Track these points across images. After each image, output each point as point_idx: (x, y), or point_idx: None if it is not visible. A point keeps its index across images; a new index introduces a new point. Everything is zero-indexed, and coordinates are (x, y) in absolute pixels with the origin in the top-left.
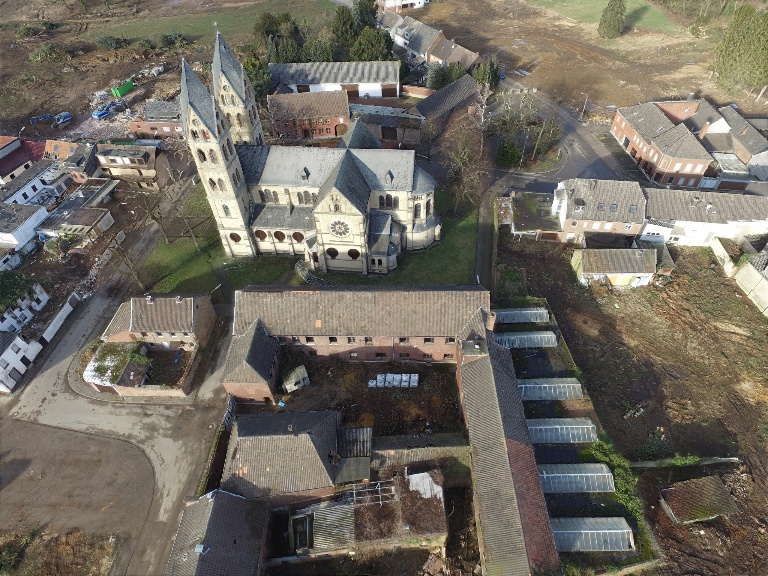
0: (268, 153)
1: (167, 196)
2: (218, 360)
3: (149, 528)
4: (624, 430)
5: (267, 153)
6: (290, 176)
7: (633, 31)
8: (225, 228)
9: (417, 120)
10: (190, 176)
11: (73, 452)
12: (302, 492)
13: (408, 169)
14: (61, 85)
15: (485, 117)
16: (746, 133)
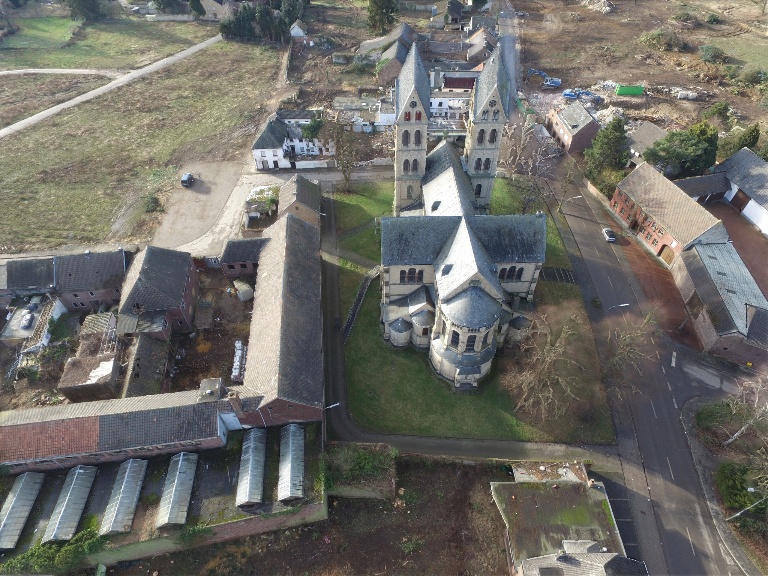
0: (446, 170)
1: None
2: None
3: None
4: None
5: (446, 169)
6: (432, 199)
7: None
8: None
9: (731, 323)
10: None
11: (211, 207)
12: None
13: (458, 280)
14: (611, 63)
15: None
16: None
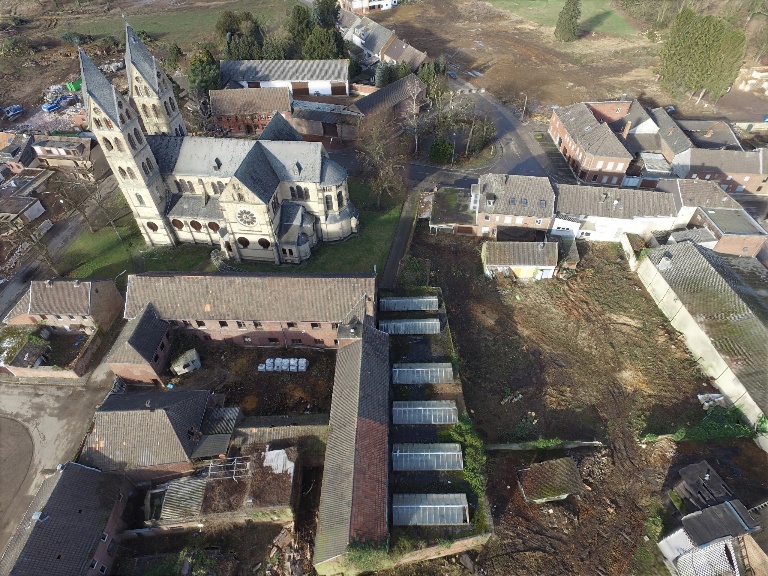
0: (181, 144)
1: (102, 187)
2: None
3: (17, 501)
4: (499, 415)
5: (180, 143)
6: (203, 166)
7: (591, 35)
8: (141, 217)
9: (355, 117)
10: None
11: None
12: (159, 467)
13: (315, 161)
14: (19, 79)
15: (417, 114)
16: (672, 133)
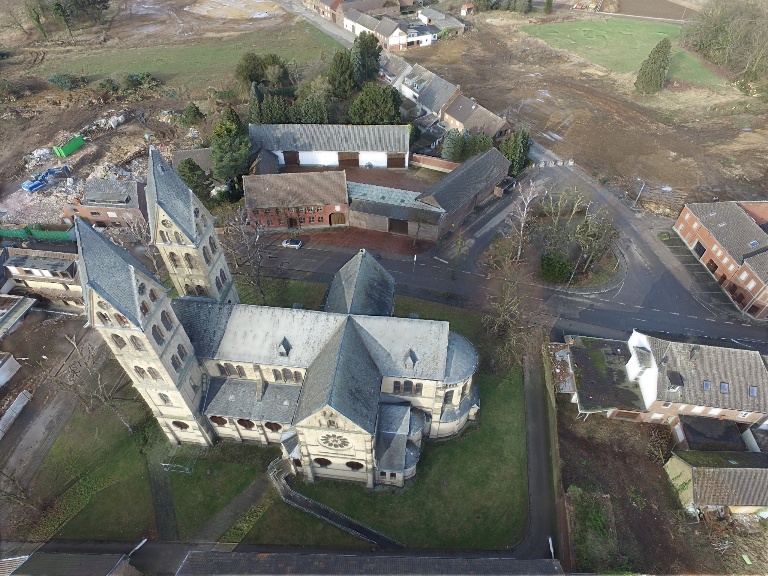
0: (229, 314)
1: None
2: None
3: None
4: None
5: (228, 314)
6: (262, 349)
7: (673, 85)
8: (165, 416)
9: (435, 214)
10: None
11: None
12: None
13: (439, 349)
14: None
15: (526, 221)
16: None
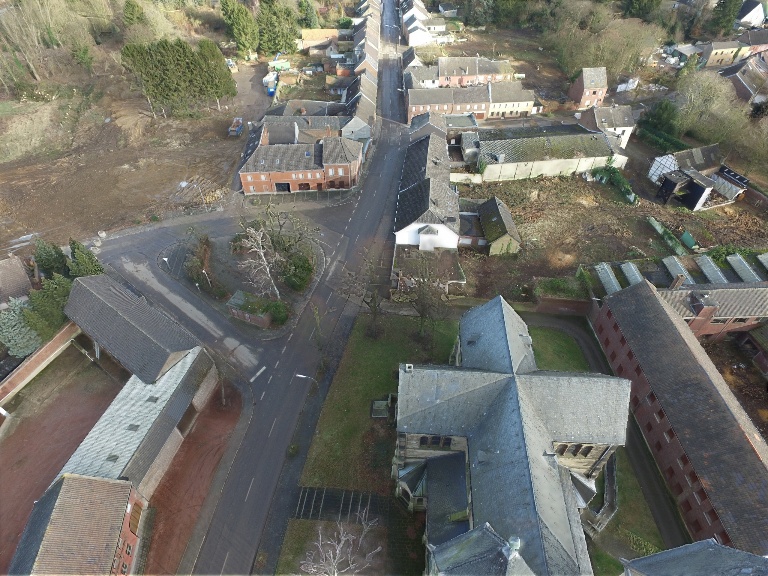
0: (546, 526)
1: None
2: None
3: None
4: None
5: (546, 528)
6: (556, 491)
7: None
8: None
9: (200, 359)
10: None
11: None
12: None
13: (514, 314)
14: None
15: None
16: (311, 122)
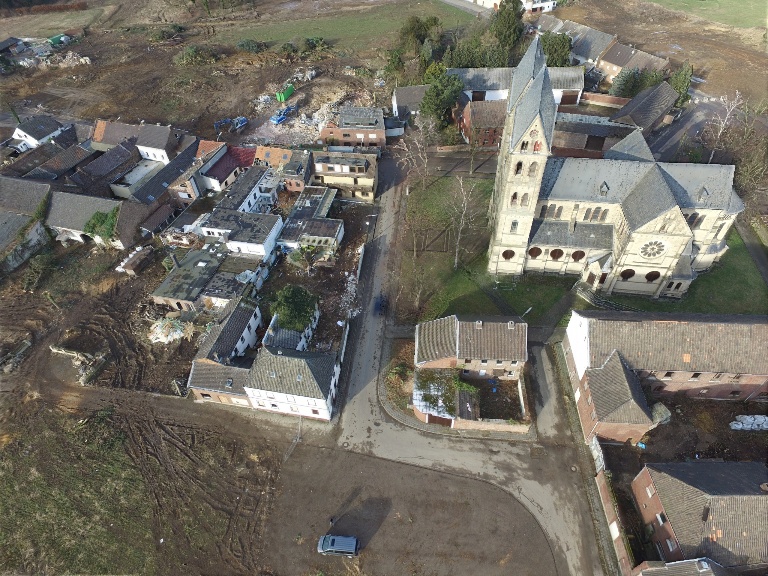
0: (562, 166)
1: (384, 206)
2: (541, 391)
3: None
4: None
5: (561, 166)
6: (585, 191)
7: None
8: (502, 245)
9: (632, 130)
10: (397, 185)
11: (432, 492)
12: None
13: (726, 186)
14: (217, 89)
15: (724, 128)
16: None
